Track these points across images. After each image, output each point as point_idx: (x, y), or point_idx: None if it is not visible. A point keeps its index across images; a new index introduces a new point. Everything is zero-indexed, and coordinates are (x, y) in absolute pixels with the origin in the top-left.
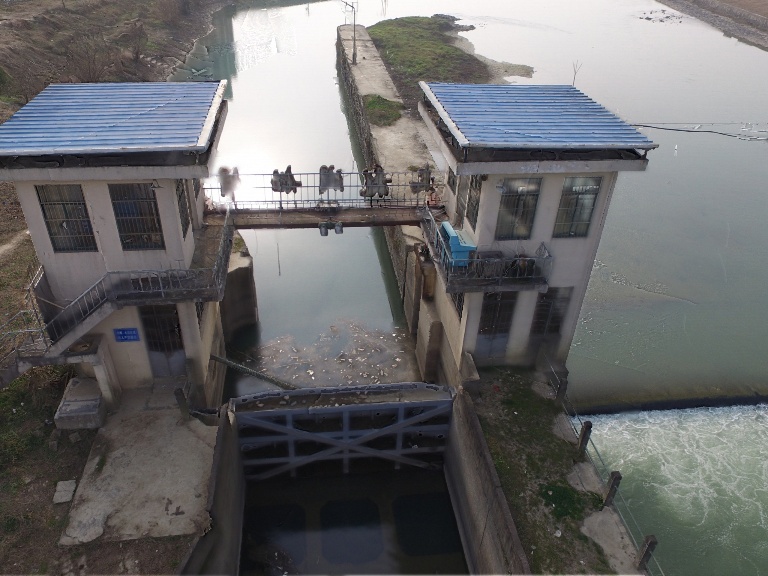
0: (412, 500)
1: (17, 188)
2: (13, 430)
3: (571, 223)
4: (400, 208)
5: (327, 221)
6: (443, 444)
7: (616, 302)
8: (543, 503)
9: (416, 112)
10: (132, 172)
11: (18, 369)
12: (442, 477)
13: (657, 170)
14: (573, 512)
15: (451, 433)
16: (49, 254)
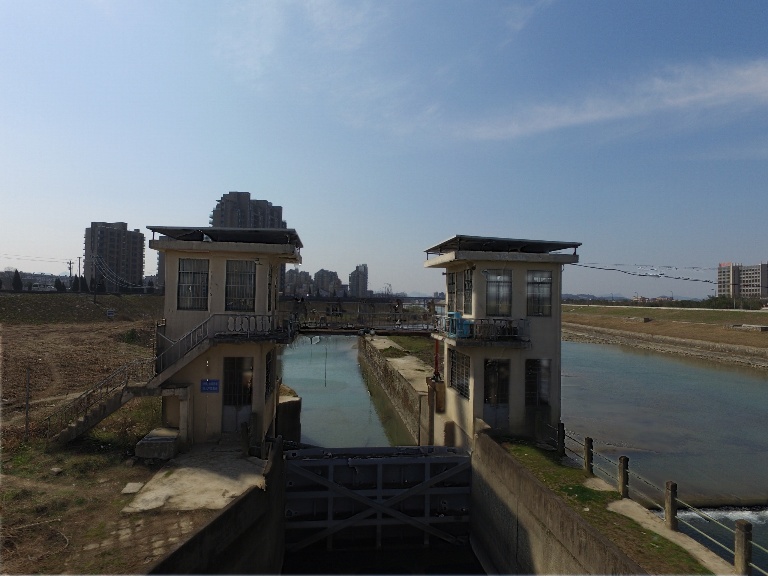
0: (443, 569)
1: (167, 260)
2: (98, 455)
3: (538, 305)
4: (415, 330)
5: (364, 329)
6: (466, 514)
7: None
8: (566, 494)
9: None
10: (246, 246)
11: (121, 399)
12: (469, 551)
13: (599, 393)
14: (595, 499)
15: (473, 489)
16: (173, 311)
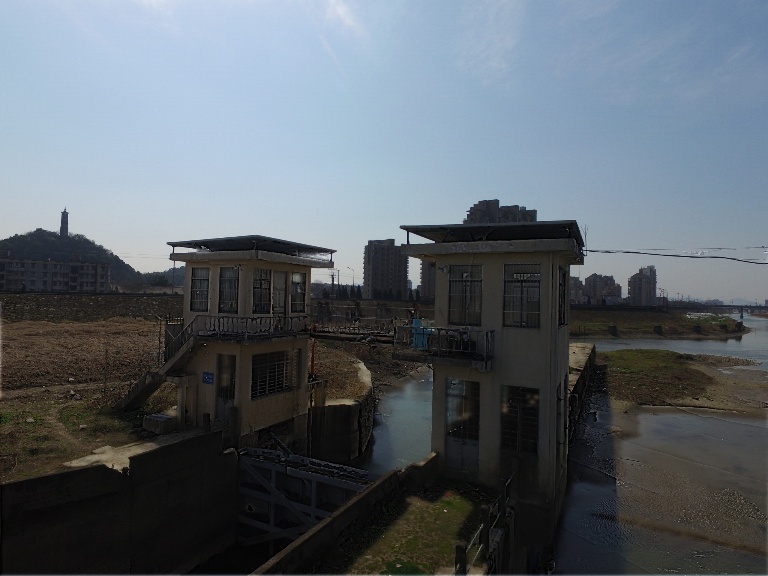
0: None
1: None
2: None
3: (520, 312)
4: None
5: None
6: None
7: (762, 551)
8: (380, 570)
9: (609, 390)
10: (225, 254)
11: (146, 380)
12: None
13: None
14: None
15: None
16: (188, 312)
